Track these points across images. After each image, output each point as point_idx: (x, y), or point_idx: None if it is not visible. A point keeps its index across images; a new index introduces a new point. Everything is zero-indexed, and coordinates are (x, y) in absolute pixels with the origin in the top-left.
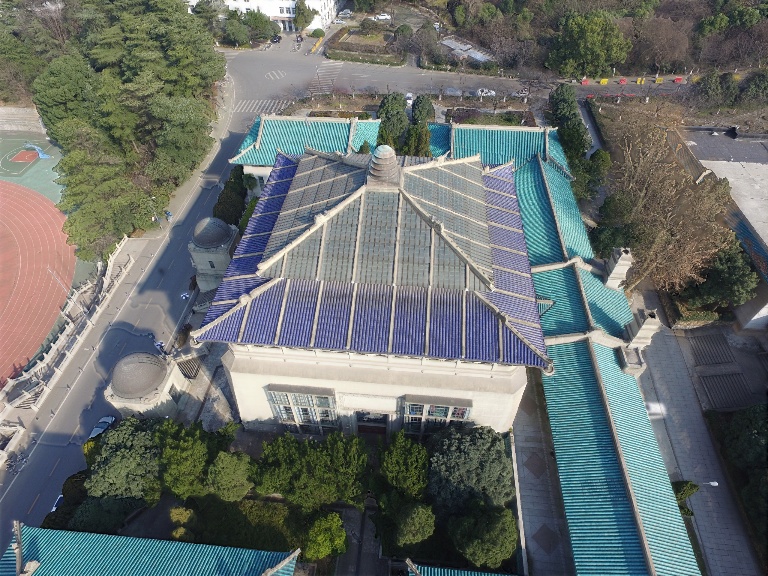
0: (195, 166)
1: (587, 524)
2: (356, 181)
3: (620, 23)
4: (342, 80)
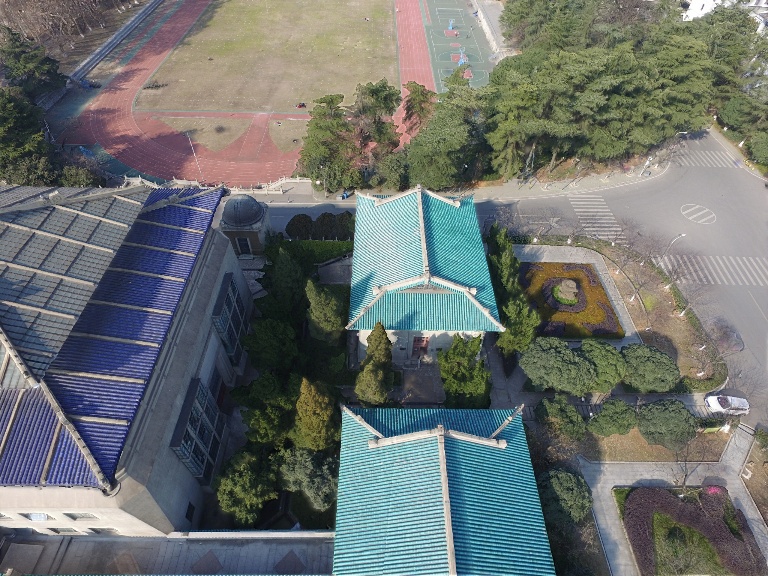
0: None
1: None
2: None
3: None
4: (742, 293)
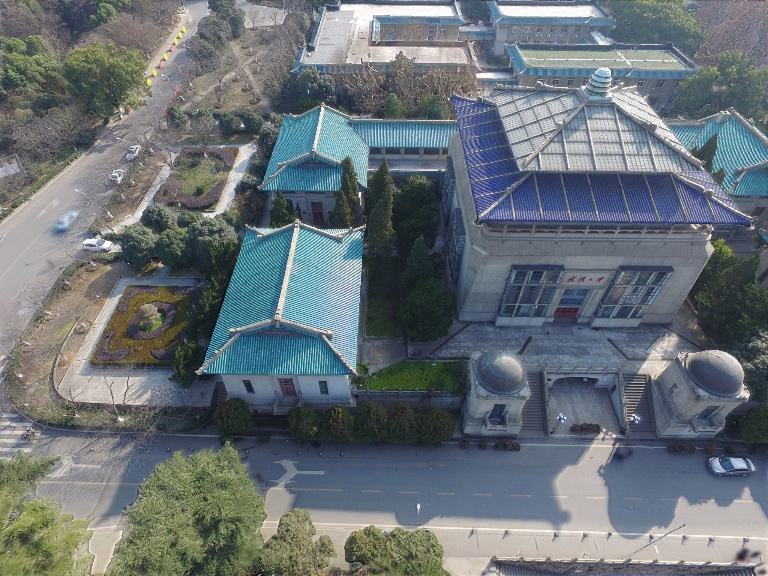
0: (265, 513)
1: None
2: (599, 112)
3: (101, 41)
4: None
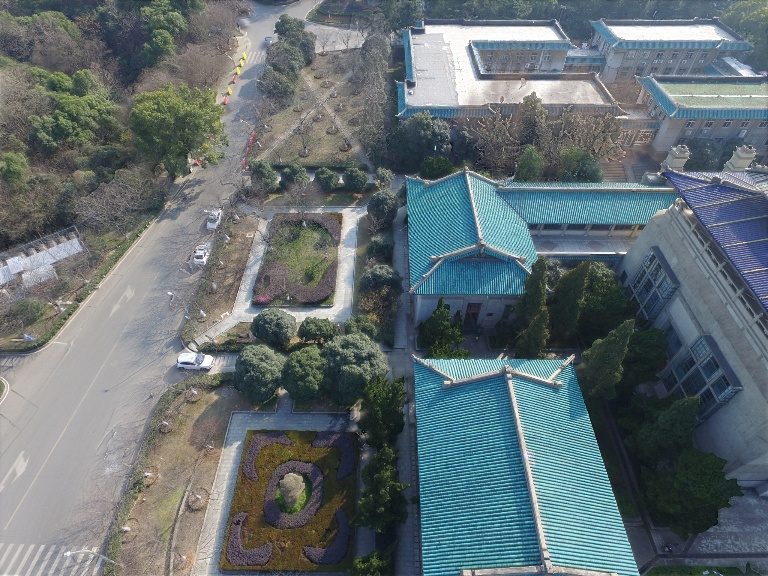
0: None
1: None
2: None
3: (171, 82)
4: (20, 524)
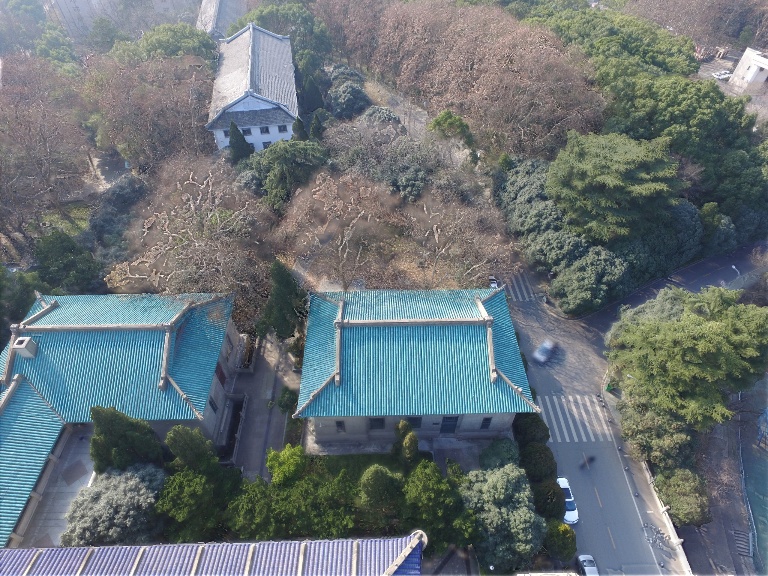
0: None
1: (24, 463)
2: None
3: None
4: None
